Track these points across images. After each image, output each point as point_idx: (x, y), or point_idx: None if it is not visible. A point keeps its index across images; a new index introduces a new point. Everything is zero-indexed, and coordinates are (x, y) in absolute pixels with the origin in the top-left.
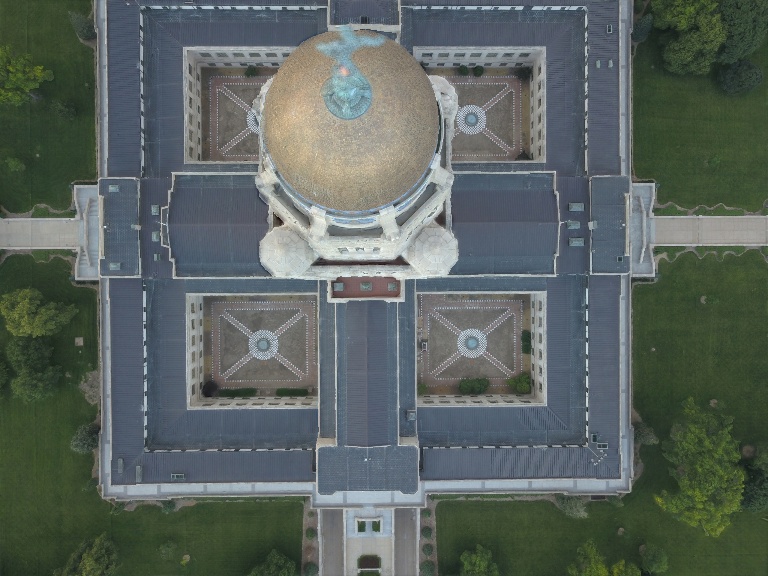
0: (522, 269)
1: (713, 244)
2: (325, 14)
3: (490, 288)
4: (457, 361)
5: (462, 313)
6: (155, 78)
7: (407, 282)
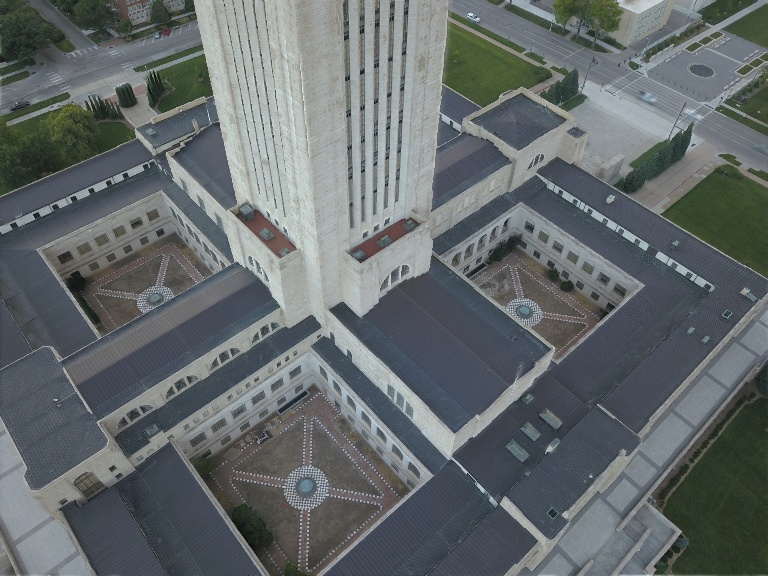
0: (426, 399)
1: None
2: None
3: (379, 413)
4: (271, 488)
5: (333, 449)
6: None
7: (312, 323)
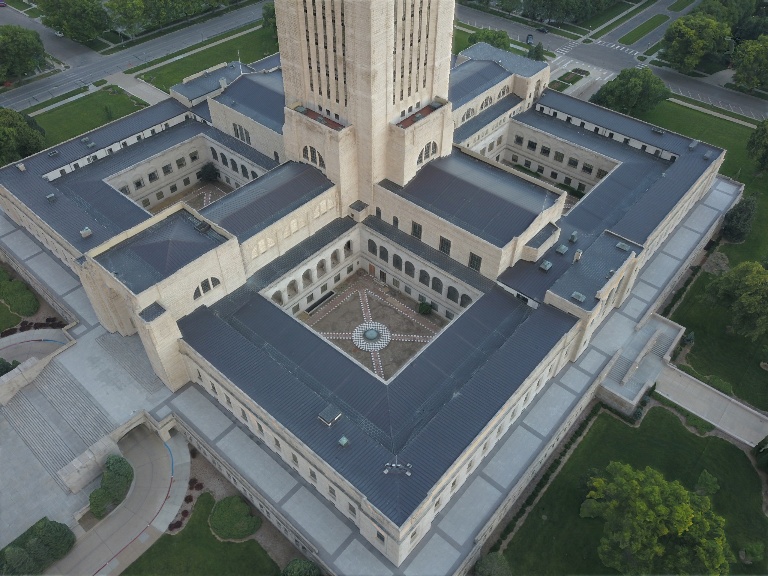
0: None
1: (168, 95)
2: (218, 312)
3: None
4: None
5: None
6: (448, 387)
7: None
